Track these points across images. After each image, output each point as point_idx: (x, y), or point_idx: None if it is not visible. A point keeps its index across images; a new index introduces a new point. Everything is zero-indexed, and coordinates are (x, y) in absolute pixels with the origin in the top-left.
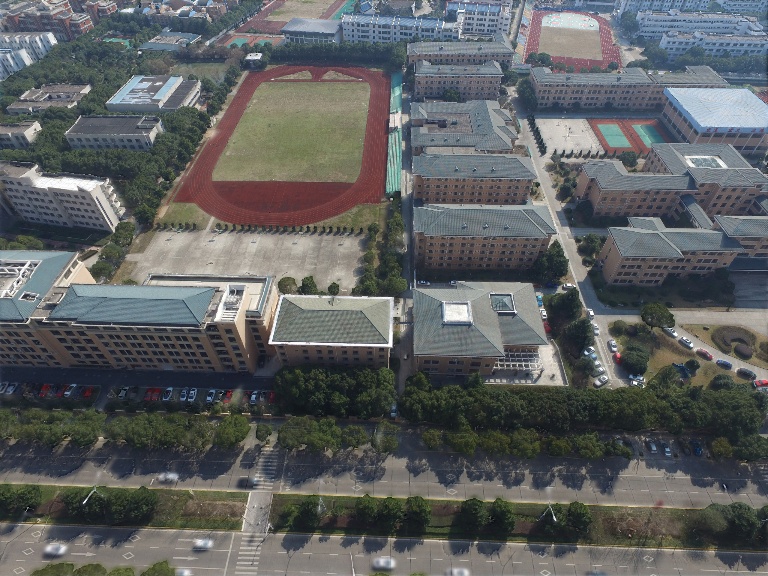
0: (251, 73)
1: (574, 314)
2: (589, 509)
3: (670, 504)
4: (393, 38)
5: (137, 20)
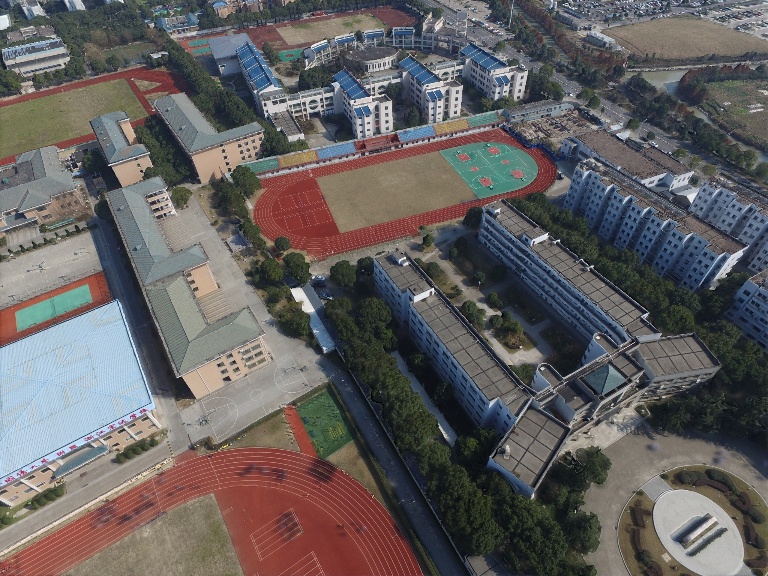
0: (141, 68)
1: None
2: None
3: None
4: None
5: None
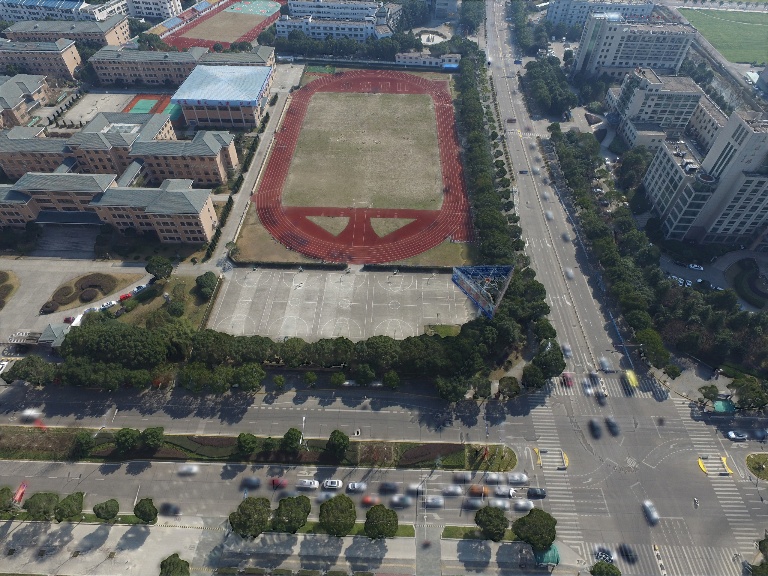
0: None
1: None
2: None
3: None
4: None
5: None
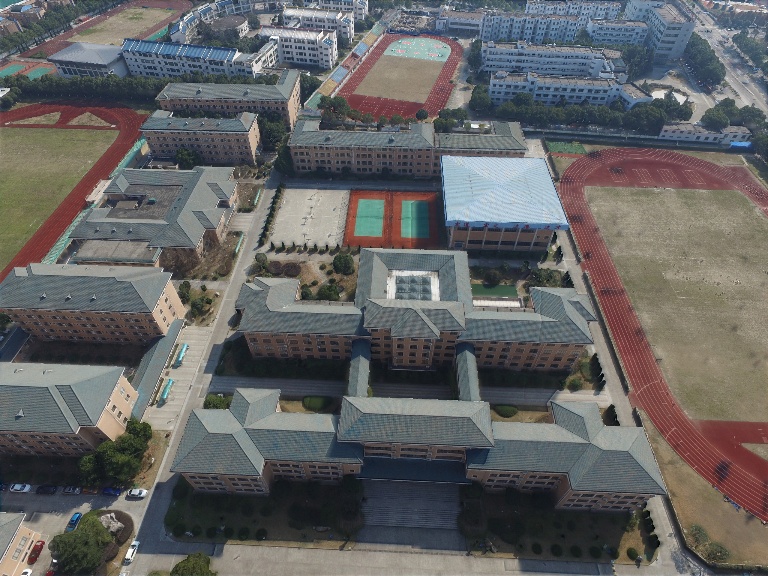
0: None
1: (72, 570)
2: None
3: None
4: (183, 70)
5: None
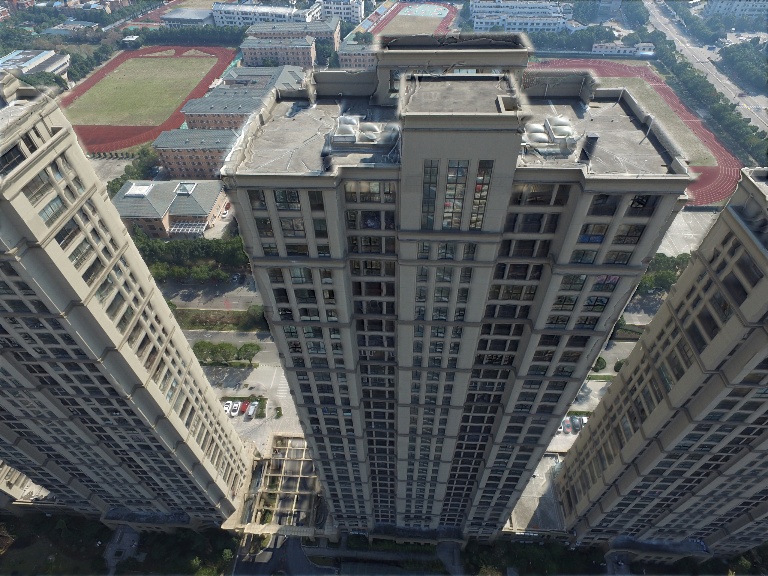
0: (125, 52)
1: None
2: (188, 311)
3: (247, 309)
4: None
5: (48, 12)
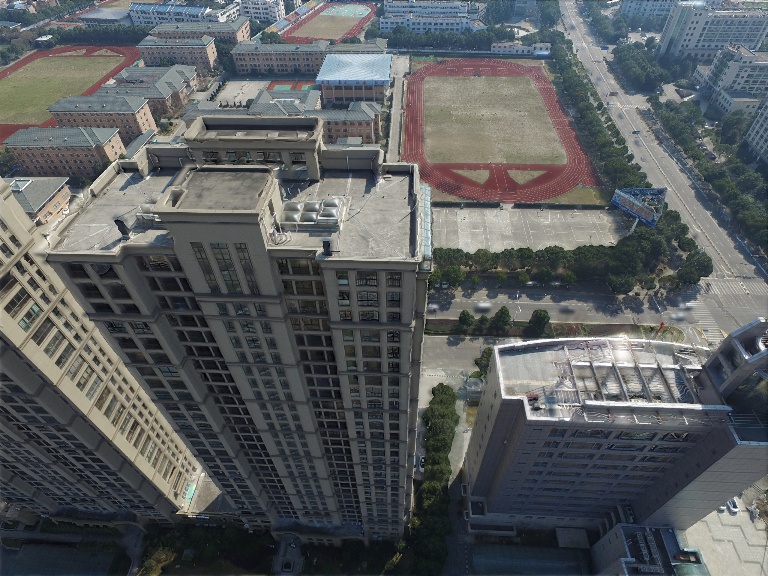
0: (38, 51)
1: None
2: None
3: None
4: None
5: None
